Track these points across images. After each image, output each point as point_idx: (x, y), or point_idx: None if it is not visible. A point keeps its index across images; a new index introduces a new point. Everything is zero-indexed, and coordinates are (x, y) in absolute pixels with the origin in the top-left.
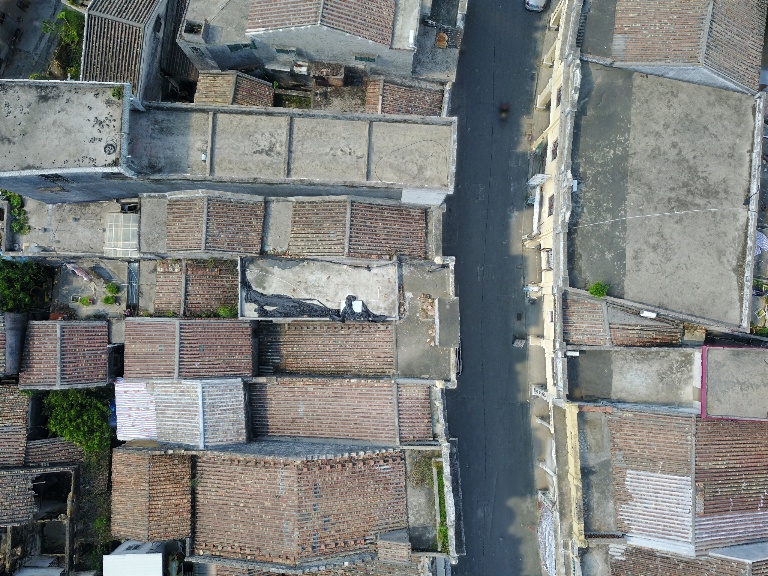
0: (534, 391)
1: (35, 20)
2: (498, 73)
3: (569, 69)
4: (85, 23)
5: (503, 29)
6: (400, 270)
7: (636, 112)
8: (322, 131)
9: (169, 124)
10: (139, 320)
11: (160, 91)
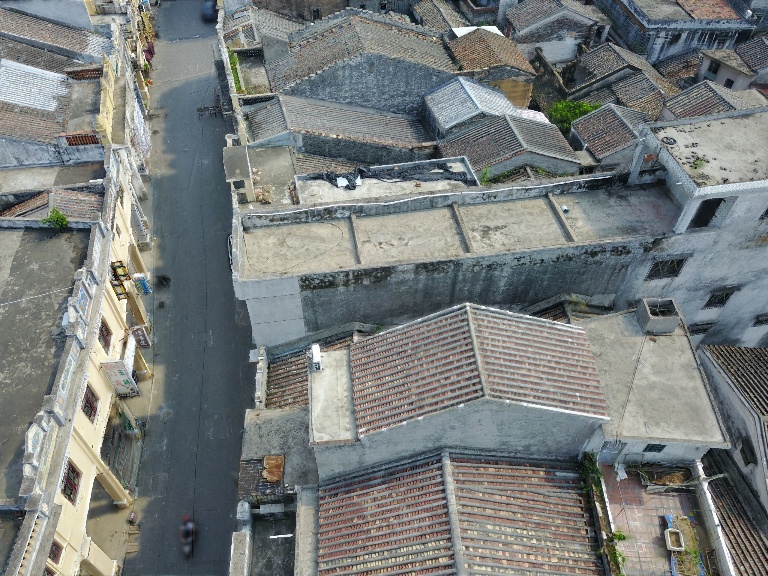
0: (147, 235)
1: None
2: None
3: (47, 489)
4: None
5: None
6: None
7: None
8: None
9: None
10: (567, 157)
11: None
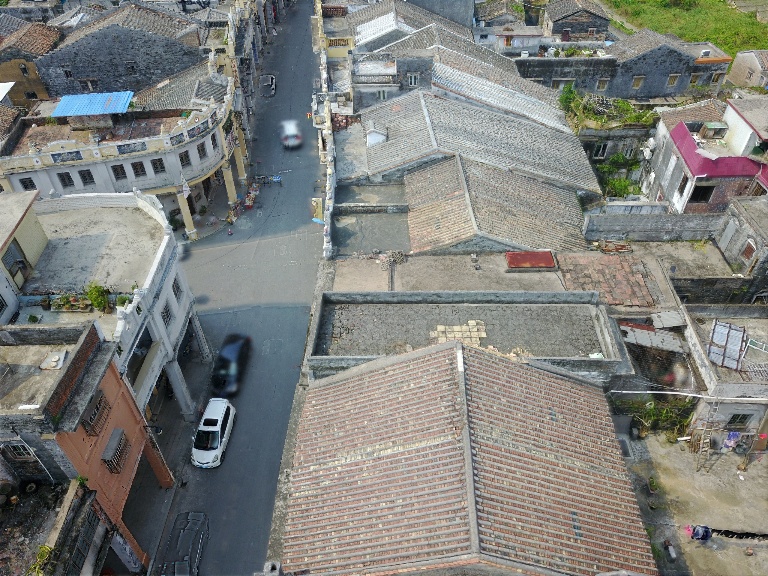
0: None
1: None
2: None
3: None
4: None
5: None
6: None
7: None
8: None
9: None
10: (56, 18)
11: None
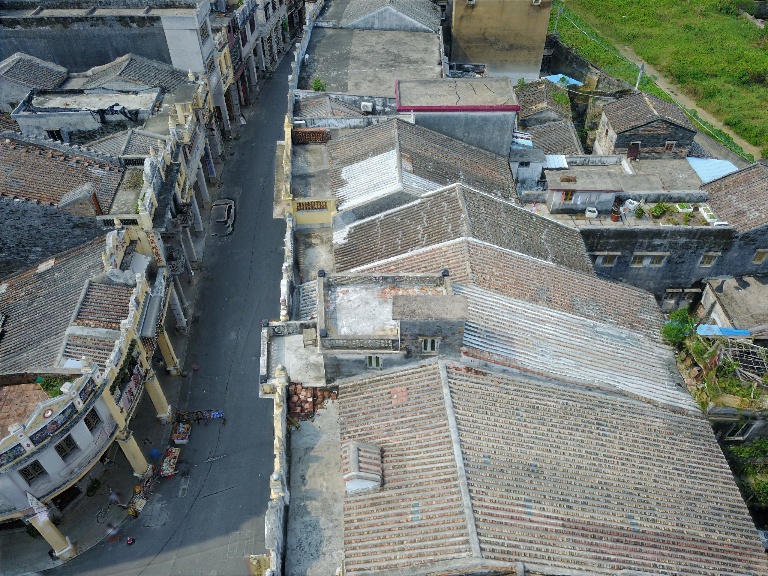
0: None
1: None
2: None
3: None
4: None
5: None
6: (162, 96)
7: (356, 40)
8: None
9: None
10: None
11: None
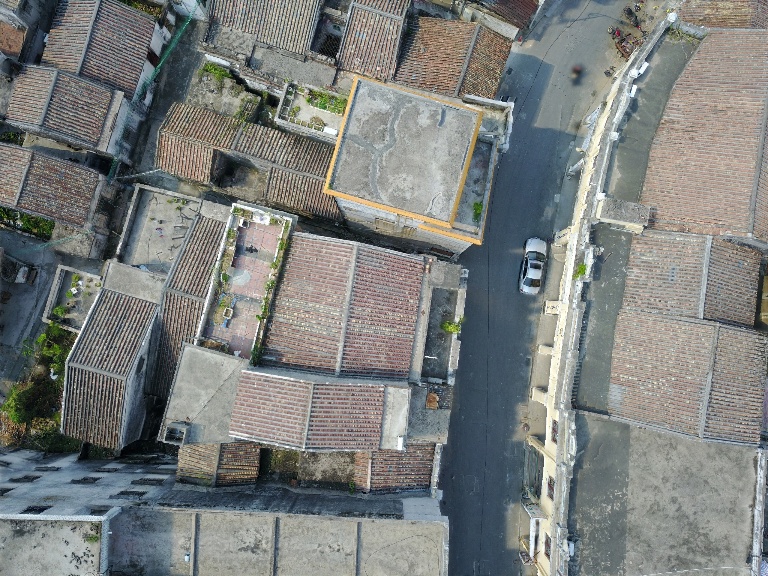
0: None
1: (17, 312)
2: (492, 358)
3: (564, 420)
4: (65, 373)
5: (497, 312)
6: None
7: (634, 465)
8: (309, 527)
9: (151, 520)
10: None
11: (144, 409)
